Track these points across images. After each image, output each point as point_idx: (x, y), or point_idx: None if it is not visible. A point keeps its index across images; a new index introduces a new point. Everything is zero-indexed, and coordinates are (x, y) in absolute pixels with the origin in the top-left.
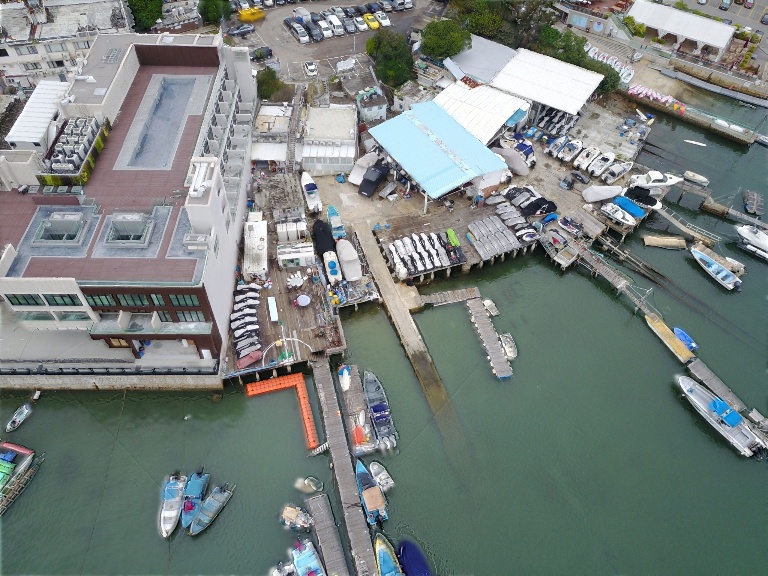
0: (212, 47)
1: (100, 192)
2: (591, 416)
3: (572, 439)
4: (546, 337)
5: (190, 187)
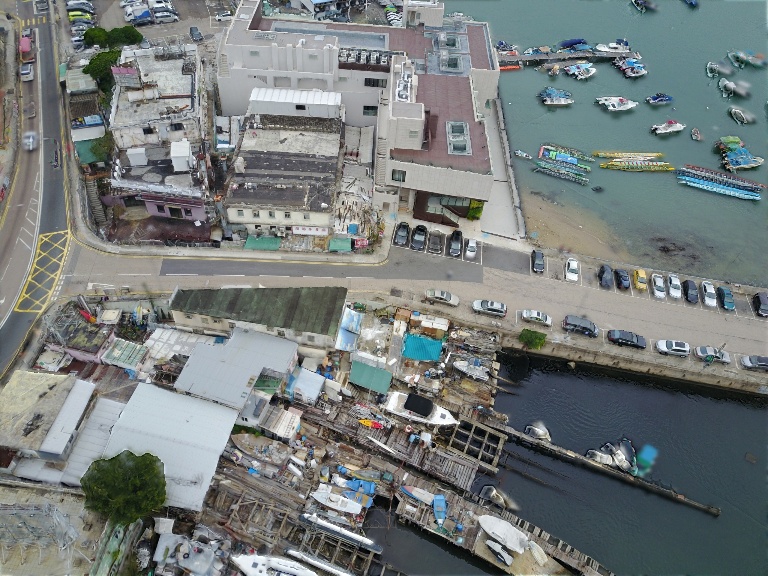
0: (259, 3)
1: (412, 54)
2: (488, 8)
3: (500, 13)
4: (446, 9)
5: (429, 7)
